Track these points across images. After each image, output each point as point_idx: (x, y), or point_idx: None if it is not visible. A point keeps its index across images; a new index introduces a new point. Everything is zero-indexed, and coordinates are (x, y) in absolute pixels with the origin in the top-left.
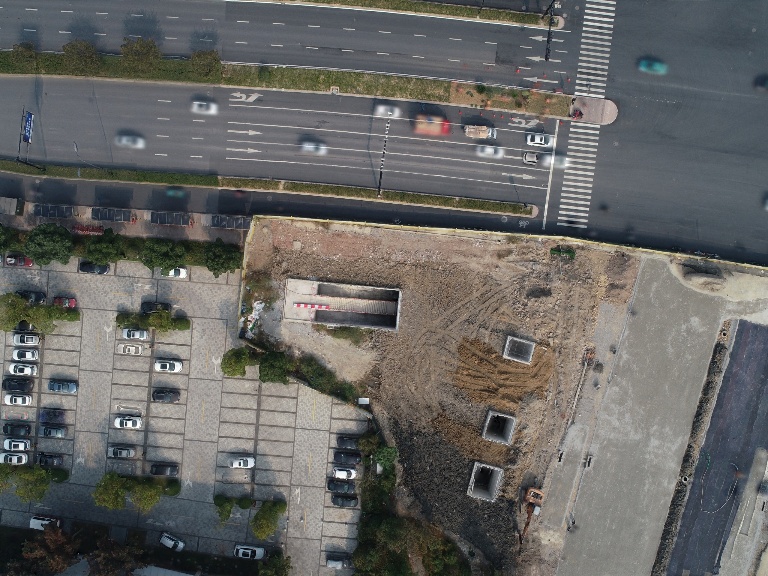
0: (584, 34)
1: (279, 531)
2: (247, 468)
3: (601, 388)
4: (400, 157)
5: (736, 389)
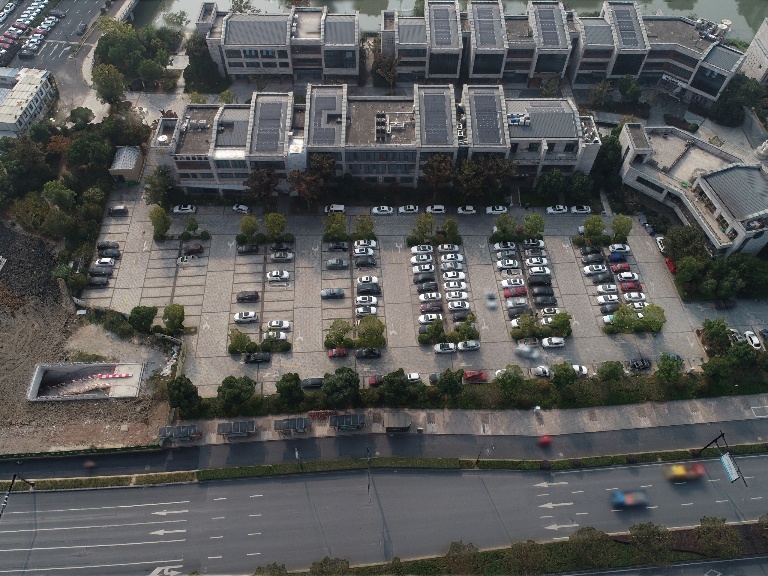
0: None
1: None
2: None
3: None
4: (3, 529)
5: None
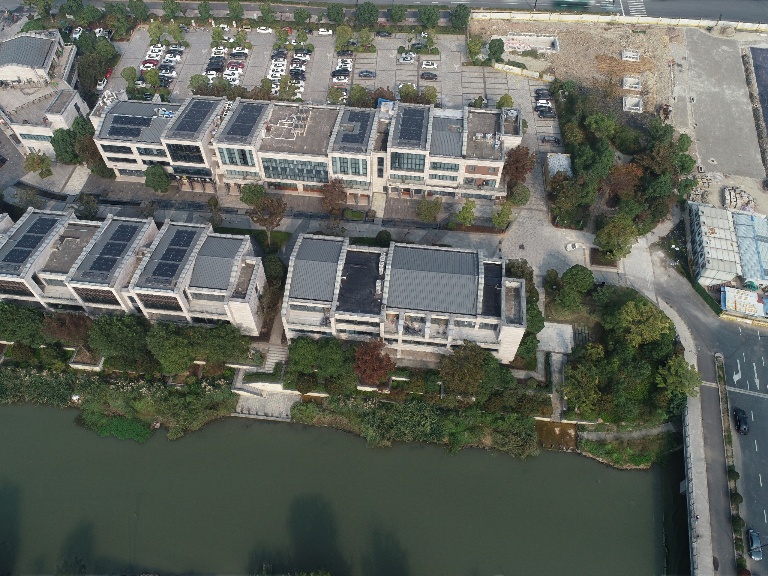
0: None
1: None
2: None
3: (685, 73)
4: (541, 0)
5: (764, 70)
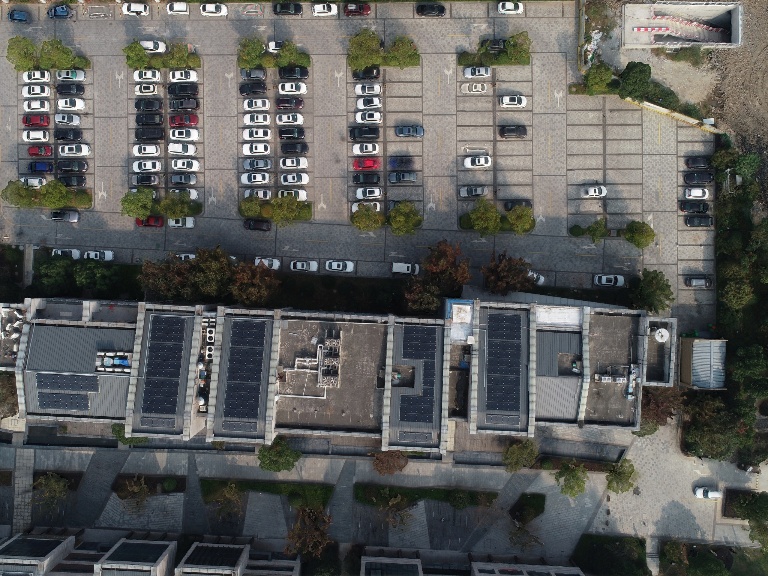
0: None
1: (635, 259)
2: (598, 199)
3: None
4: None
5: None
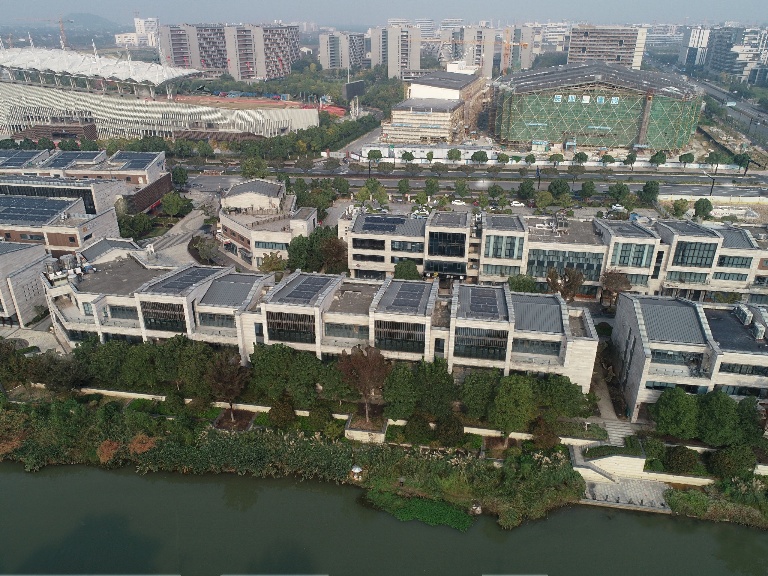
0: (767, 178)
1: None
2: None
3: None
4: None
5: None
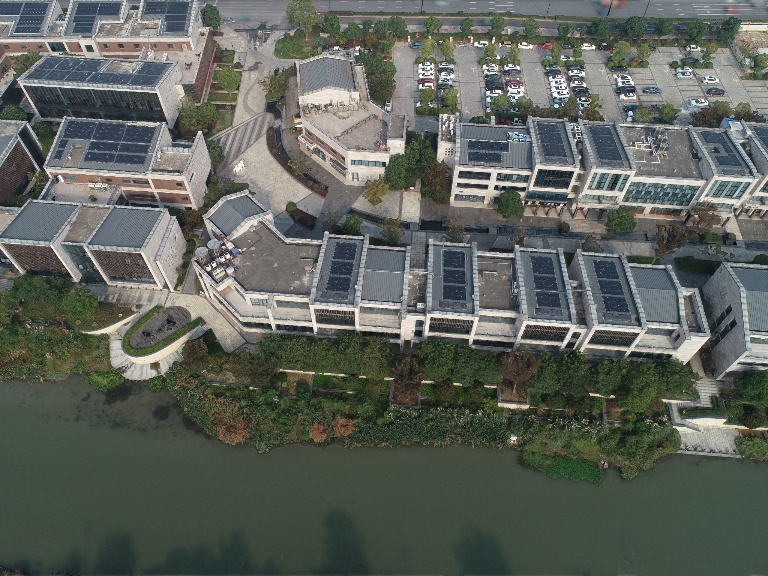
0: None
1: None
2: None
3: None
4: None
5: None
